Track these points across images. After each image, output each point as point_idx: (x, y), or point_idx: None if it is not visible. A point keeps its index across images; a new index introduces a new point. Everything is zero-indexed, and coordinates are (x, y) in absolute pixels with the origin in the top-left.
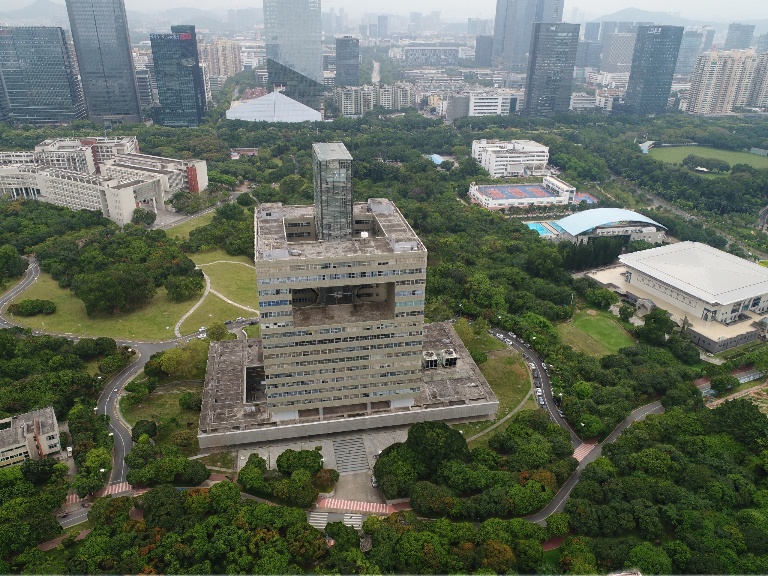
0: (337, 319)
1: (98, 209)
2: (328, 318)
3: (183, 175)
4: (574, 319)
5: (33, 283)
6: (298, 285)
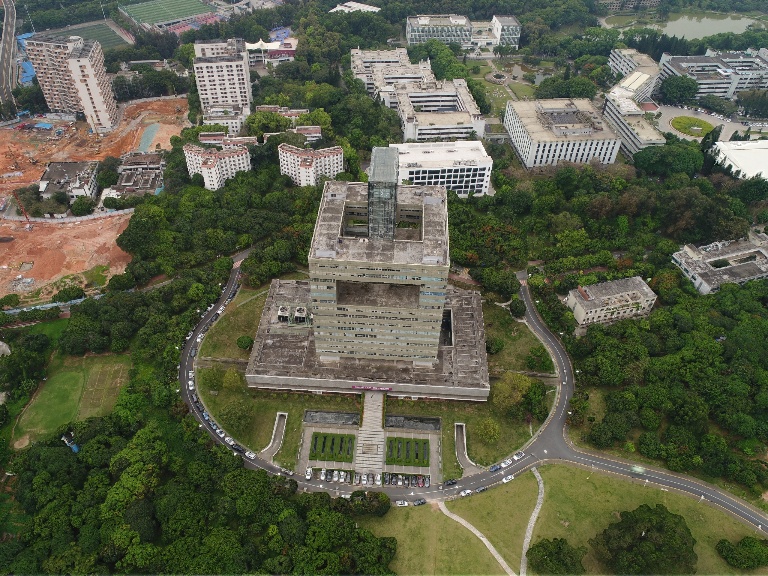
0: None
1: None
2: None
3: None
4: None
5: None
6: None
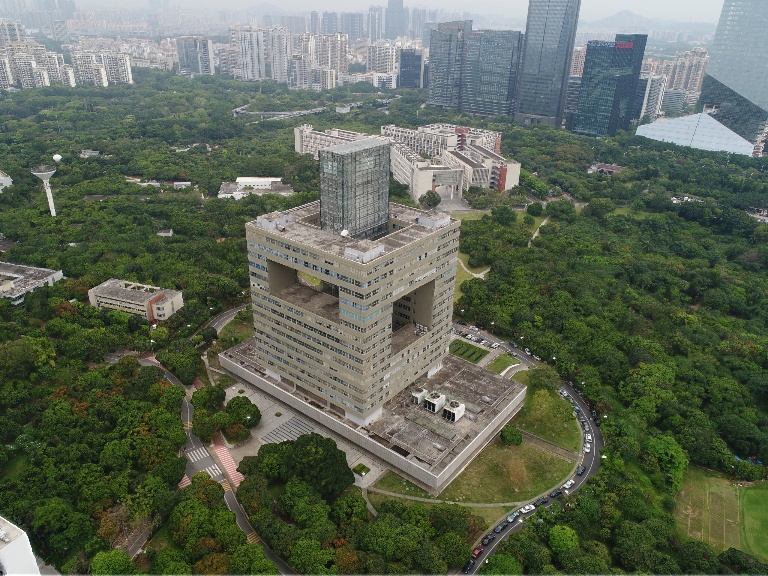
0: (307, 304)
1: (408, 184)
2: (304, 300)
3: (497, 173)
4: (754, 486)
5: None
6: (271, 256)
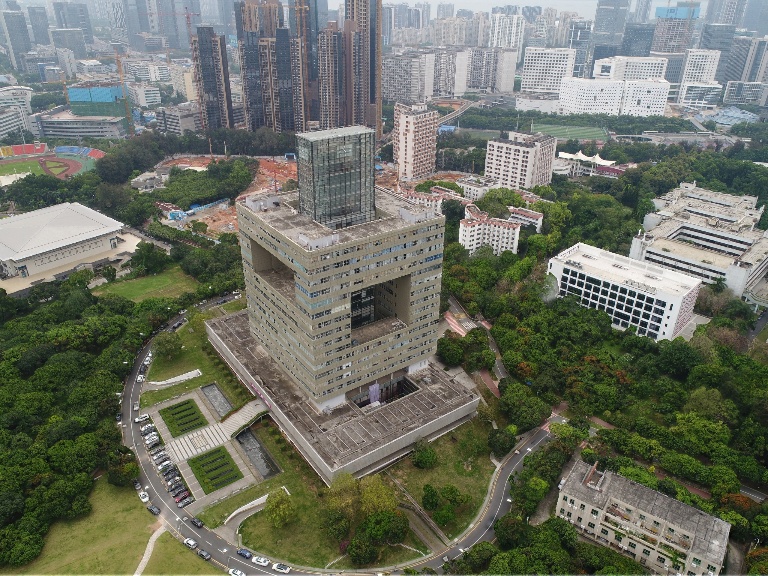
0: None
1: None
2: None
3: None
4: None
5: None
6: None
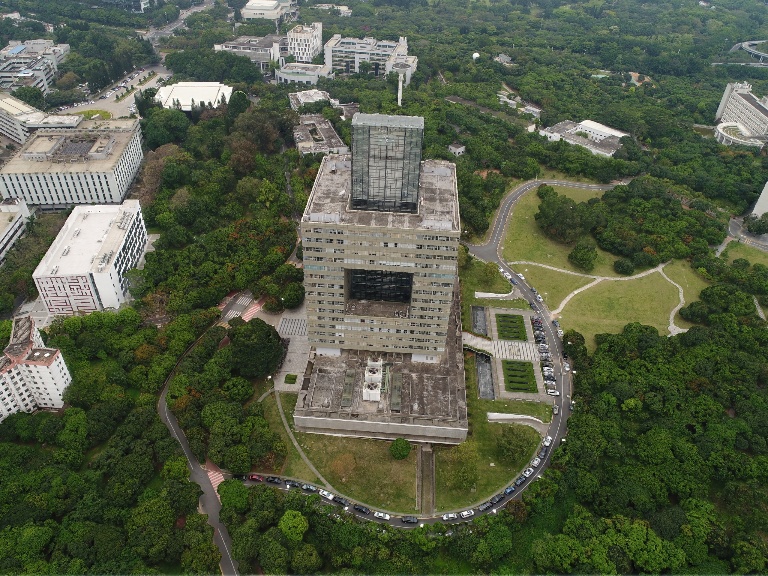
0: None
1: None
2: None
3: None
4: None
5: (591, 189)
6: None
